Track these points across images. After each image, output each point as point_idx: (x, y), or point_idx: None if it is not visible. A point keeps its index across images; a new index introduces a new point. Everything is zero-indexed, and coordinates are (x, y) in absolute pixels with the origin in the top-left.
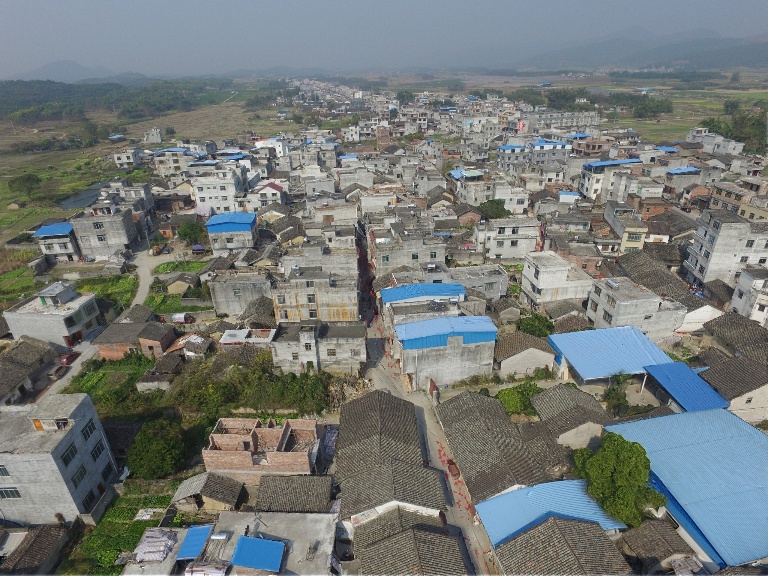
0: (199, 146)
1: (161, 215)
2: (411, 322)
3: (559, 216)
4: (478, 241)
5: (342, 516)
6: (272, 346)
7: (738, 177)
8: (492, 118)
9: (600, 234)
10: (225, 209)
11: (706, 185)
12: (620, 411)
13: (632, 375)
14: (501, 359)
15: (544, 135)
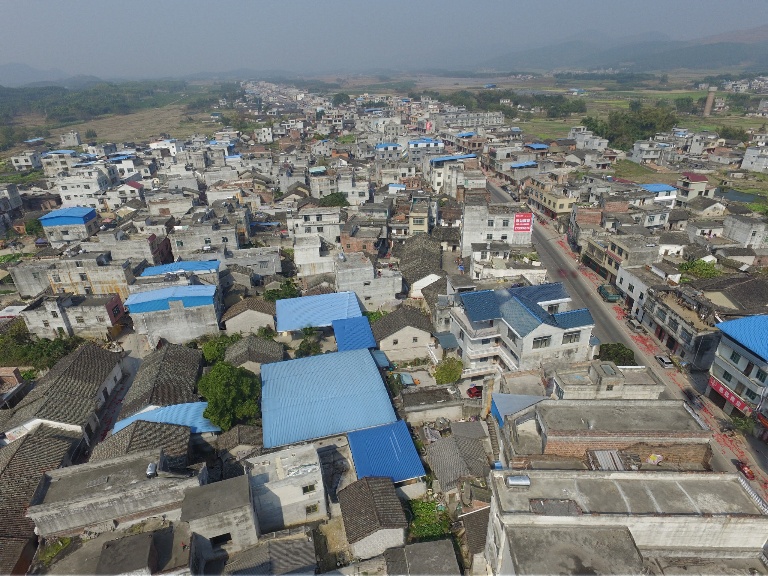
0: (97, 148)
1: (25, 213)
2: (146, 291)
3: (365, 205)
4: (288, 228)
5: None
6: (23, 315)
7: (588, 170)
8: (395, 119)
9: (398, 220)
10: (92, 206)
11: None
12: (296, 355)
13: (320, 328)
14: (223, 320)
15: (441, 134)
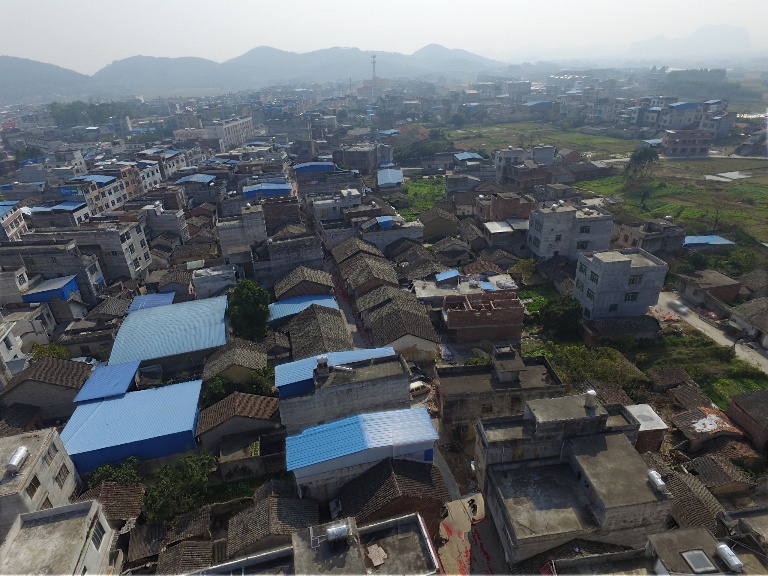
0: None
1: None
2: None
3: None
4: None
5: None
6: None
7: None
8: None
9: None
10: None
11: None
12: None
13: None
14: None
15: None
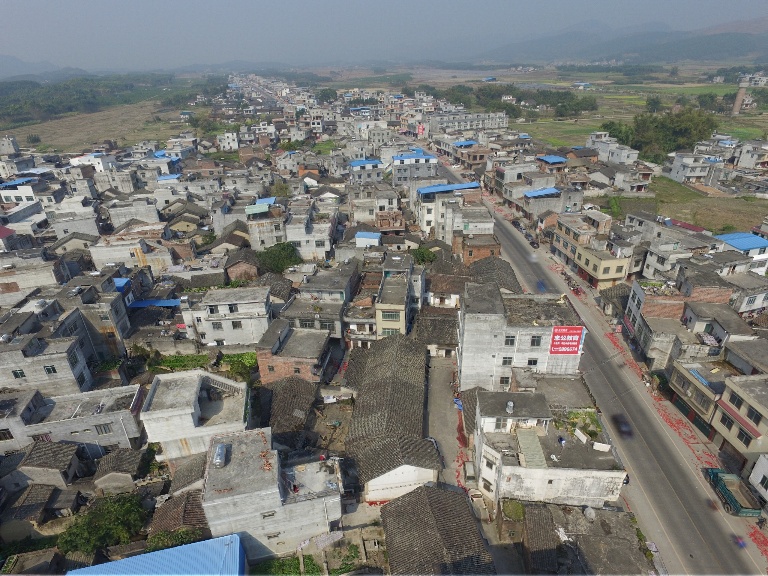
0: (7, 164)
1: None
2: None
3: (310, 280)
4: (185, 324)
5: None
6: None
7: (620, 194)
8: (380, 122)
9: (361, 306)
10: None
11: (567, 210)
12: None
13: None
14: None
15: (435, 141)
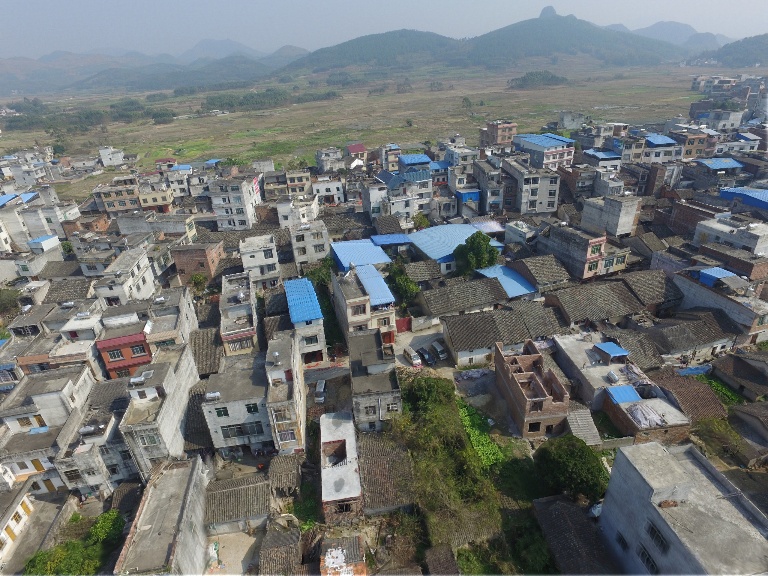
0: None
1: None
2: None
3: None
4: (127, 297)
5: (556, 331)
6: None
7: None
8: None
9: None
10: None
11: None
12: (409, 261)
13: None
14: None
15: None
